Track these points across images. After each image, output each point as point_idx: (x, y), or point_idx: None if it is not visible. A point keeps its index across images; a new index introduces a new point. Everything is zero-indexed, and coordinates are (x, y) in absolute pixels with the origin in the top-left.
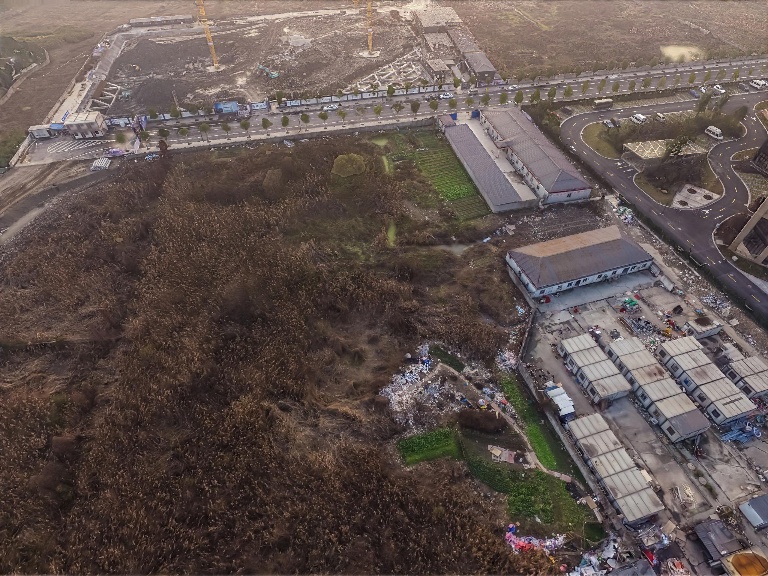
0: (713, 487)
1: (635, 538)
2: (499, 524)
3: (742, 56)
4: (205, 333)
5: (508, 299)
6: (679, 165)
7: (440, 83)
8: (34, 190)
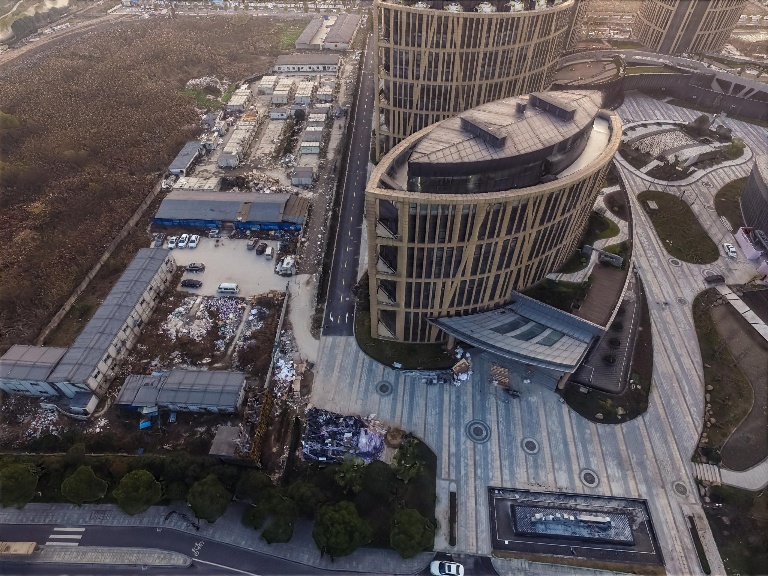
0: None
1: (226, 109)
2: (191, 106)
3: None
4: (139, 57)
5: (264, 69)
6: None
7: (337, 3)
8: (112, 22)
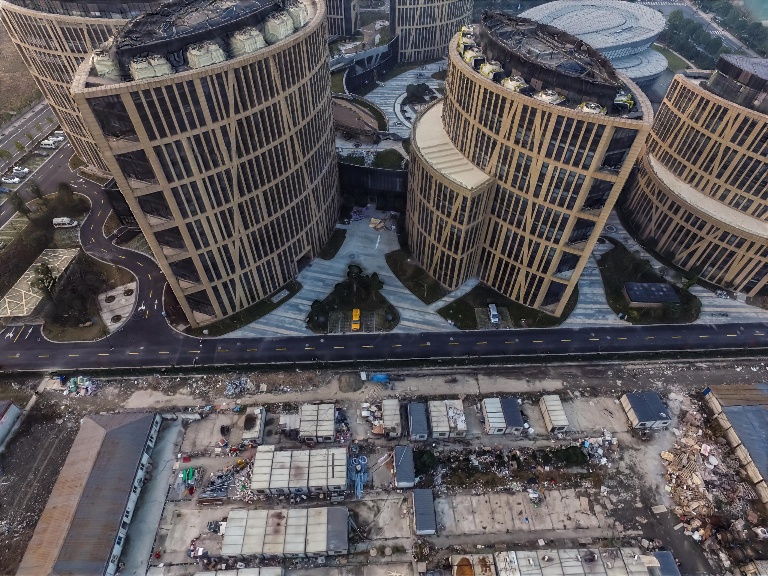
0: (396, 545)
1: None
2: None
3: (5, 120)
4: None
5: None
6: (70, 283)
7: None
8: None
